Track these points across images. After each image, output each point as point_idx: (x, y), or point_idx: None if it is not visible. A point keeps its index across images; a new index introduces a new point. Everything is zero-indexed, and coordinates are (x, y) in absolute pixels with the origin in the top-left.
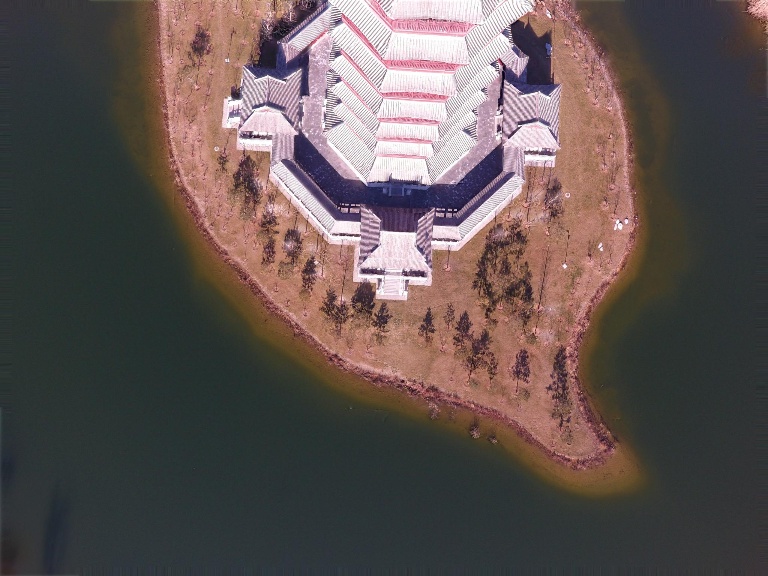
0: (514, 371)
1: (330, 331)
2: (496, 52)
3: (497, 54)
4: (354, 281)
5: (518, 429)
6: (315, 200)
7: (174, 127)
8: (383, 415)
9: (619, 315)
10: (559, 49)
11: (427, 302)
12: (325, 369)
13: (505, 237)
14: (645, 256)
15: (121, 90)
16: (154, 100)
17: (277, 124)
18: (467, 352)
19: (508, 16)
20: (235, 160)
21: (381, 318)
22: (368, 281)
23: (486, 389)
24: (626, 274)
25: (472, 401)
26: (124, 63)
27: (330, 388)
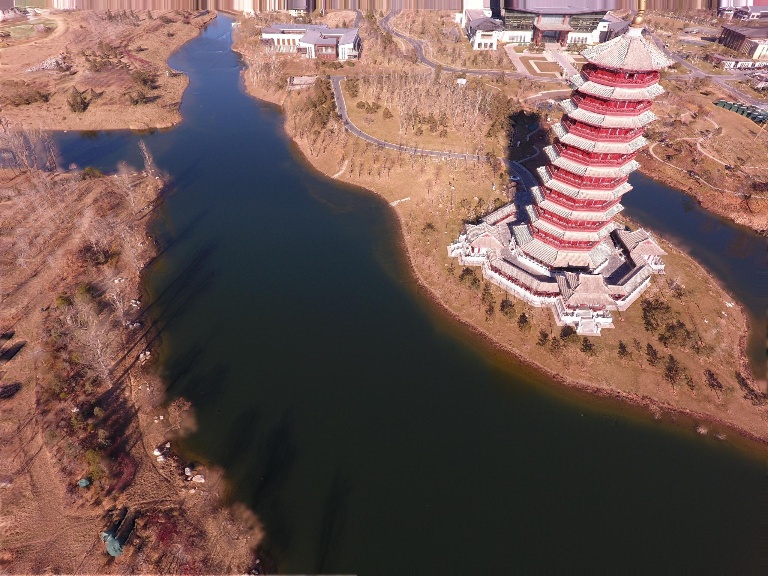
0: (708, 384)
1: (551, 352)
2: (634, 167)
3: (634, 168)
4: (558, 325)
5: (738, 429)
6: (524, 274)
7: (415, 260)
8: (612, 420)
9: (767, 358)
10: None
11: (617, 337)
12: (551, 385)
13: (653, 305)
14: (760, 325)
15: (379, 249)
16: (400, 251)
17: (491, 243)
18: (665, 361)
19: (641, 143)
20: (459, 269)
21: (586, 346)
22: (568, 325)
23: (692, 398)
24: (754, 333)
25: (685, 408)
26: (380, 239)
27: (560, 398)
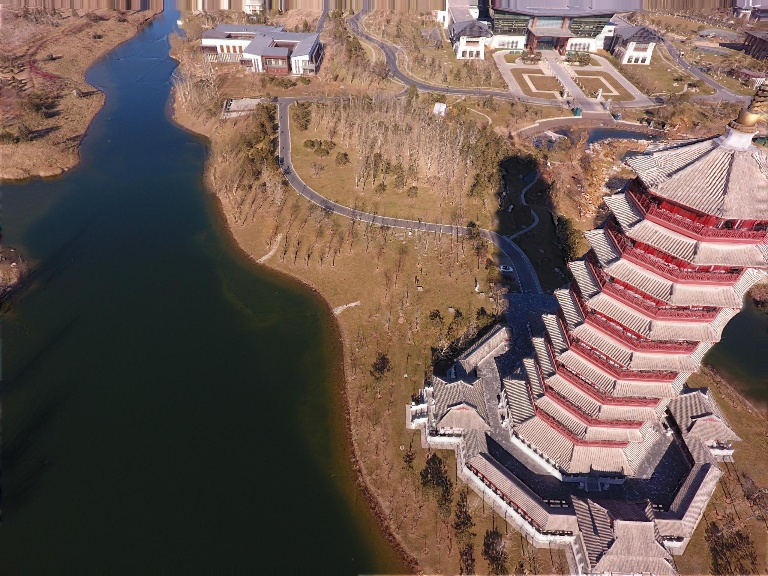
0: None
1: None
2: None
3: (710, 343)
4: None
5: None
6: (522, 492)
7: (357, 430)
8: None
9: None
10: None
11: None
12: None
13: (726, 538)
14: None
15: (307, 401)
16: (337, 408)
17: (471, 420)
18: None
19: (726, 313)
20: (422, 458)
21: None
22: None
23: None
24: None
25: None
26: (311, 380)
27: None
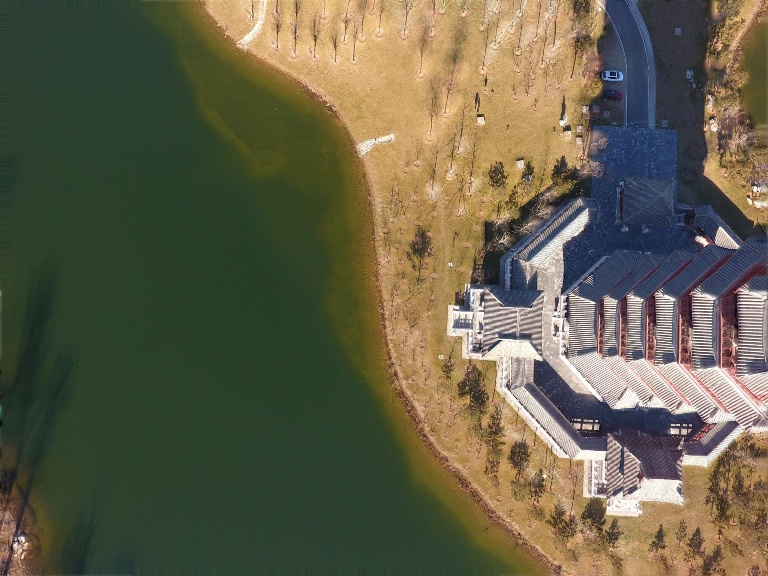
0: None
1: (561, 549)
2: None
3: None
4: (584, 496)
5: None
6: (559, 428)
7: (392, 329)
8: None
9: None
10: None
11: (659, 519)
12: None
13: (738, 450)
14: None
15: (334, 286)
16: (369, 299)
17: (522, 350)
18: None
19: None
20: (461, 369)
21: (612, 535)
22: None
23: None
24: None
25: None
26: (337, 258)
27: None
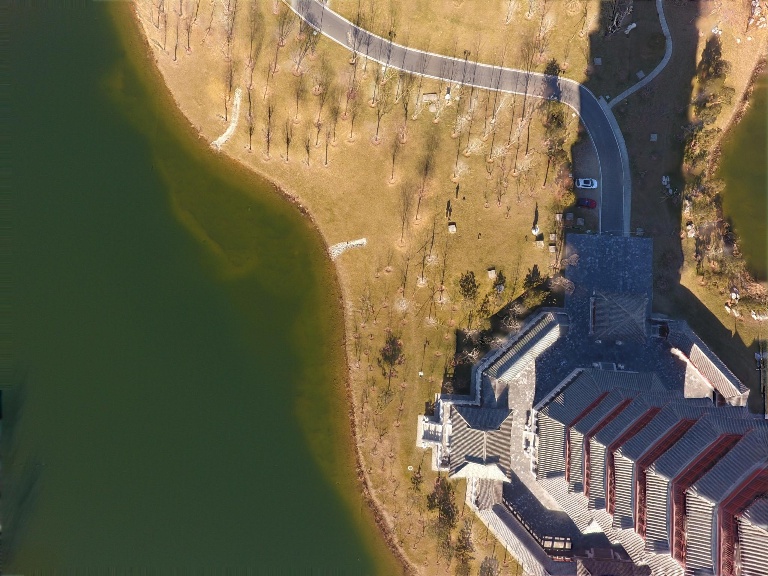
0: None
1: None
2: None
3: None
4: None
5: None
6: (528, 552)
7: (362, 436)
8: None
9: None
10: (767, 357)
11: None
12: None
13: None
14: None
15: (305, 390)
16: (340, 404)
17: (489, 472)
18: None
19: None
20: (430, 482)
21: None
22: None
23: None
24: None
25: None
26: (307, 361)
27: None
